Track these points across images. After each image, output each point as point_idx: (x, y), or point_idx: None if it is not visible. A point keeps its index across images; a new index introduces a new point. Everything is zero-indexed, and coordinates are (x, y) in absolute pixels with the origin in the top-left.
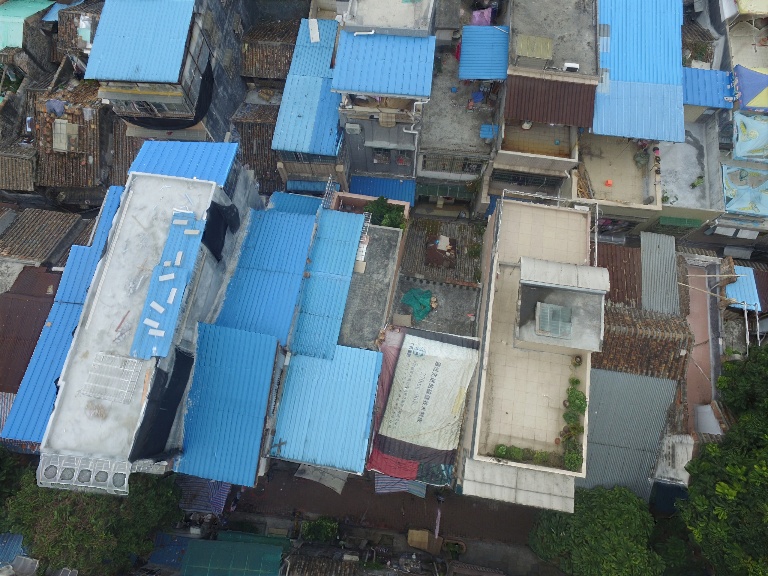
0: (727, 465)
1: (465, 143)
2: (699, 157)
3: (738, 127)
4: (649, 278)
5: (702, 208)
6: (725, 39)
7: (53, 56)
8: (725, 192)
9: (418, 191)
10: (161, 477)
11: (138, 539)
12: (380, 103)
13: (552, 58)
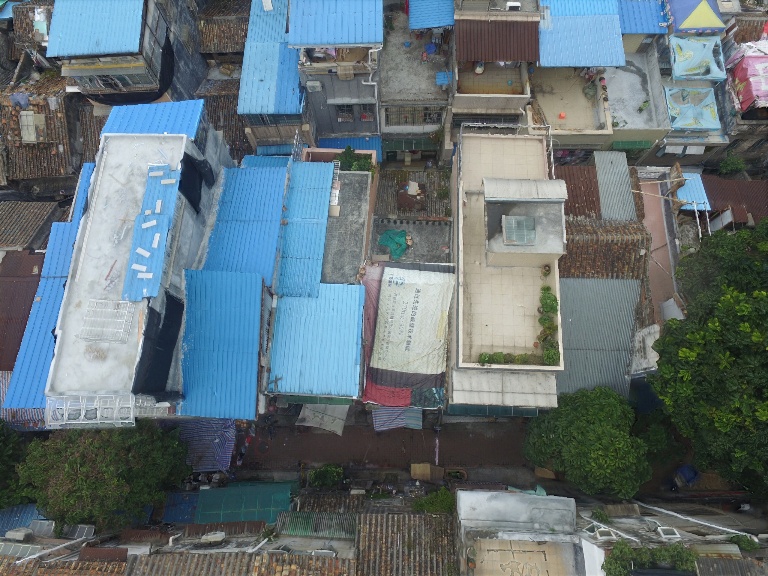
0: (687, 334)
1: (423, 92)
2: (643, 84)
3: (674, 49)
4: (606, 191)
5: (650, 128)
6: None
7: (11, 54)
8: (669, 111)
9: (385, 148)
10: (165, 432)
11: (150, 490)
12: (337, 57)
13: (495, 1)
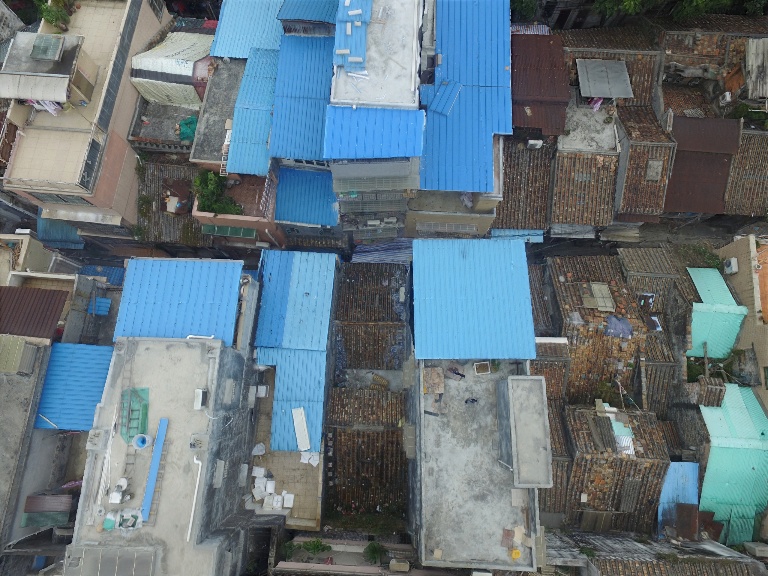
0: None
1: None
2: None
3: None
4: None
5: None
6: None
7: (672, 427)
8: None
9: None
10: None
11: None
12: None
13: None
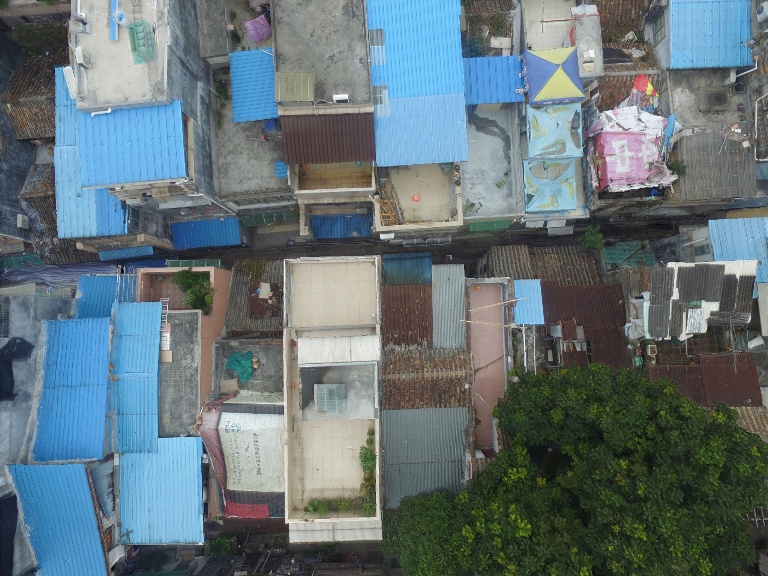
0: (473, 509)
1: (265, 182)
2: (506, 150)
3: (530, 123)
4: (439, 314)
5: (502, 215)
6: (520, 9)
7: None
8: (526, 191)
9: (244, 223)
10: None
11: None
12: None
13: (323, 86)
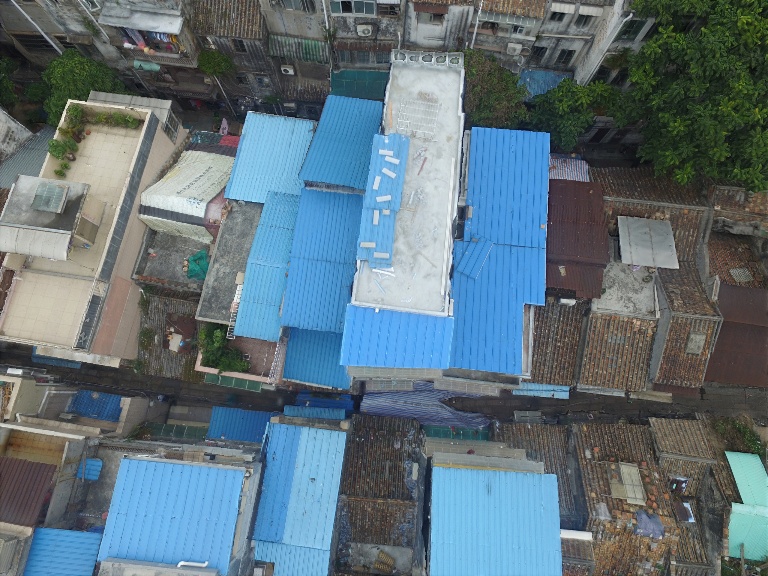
0: None
1: None
2: None
3: None
4: None
5: None
6: None
7: None
8: None
9: None
10: None
11: None
12: None
13: None
